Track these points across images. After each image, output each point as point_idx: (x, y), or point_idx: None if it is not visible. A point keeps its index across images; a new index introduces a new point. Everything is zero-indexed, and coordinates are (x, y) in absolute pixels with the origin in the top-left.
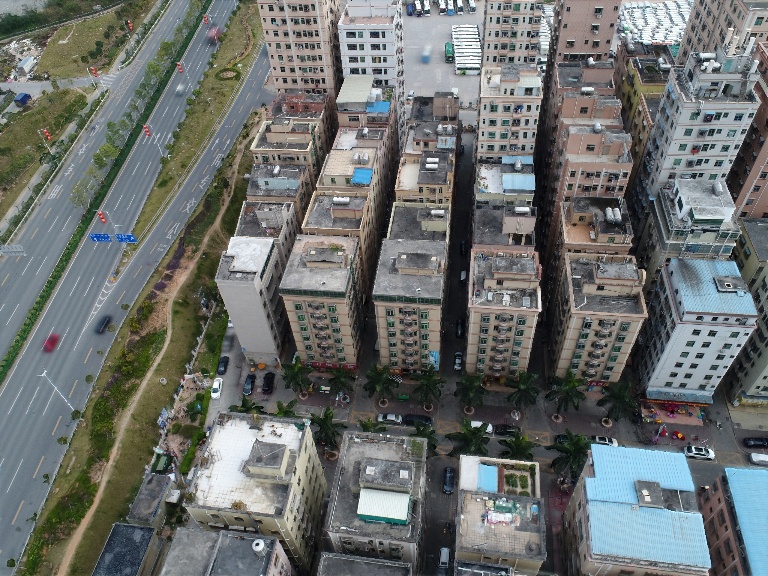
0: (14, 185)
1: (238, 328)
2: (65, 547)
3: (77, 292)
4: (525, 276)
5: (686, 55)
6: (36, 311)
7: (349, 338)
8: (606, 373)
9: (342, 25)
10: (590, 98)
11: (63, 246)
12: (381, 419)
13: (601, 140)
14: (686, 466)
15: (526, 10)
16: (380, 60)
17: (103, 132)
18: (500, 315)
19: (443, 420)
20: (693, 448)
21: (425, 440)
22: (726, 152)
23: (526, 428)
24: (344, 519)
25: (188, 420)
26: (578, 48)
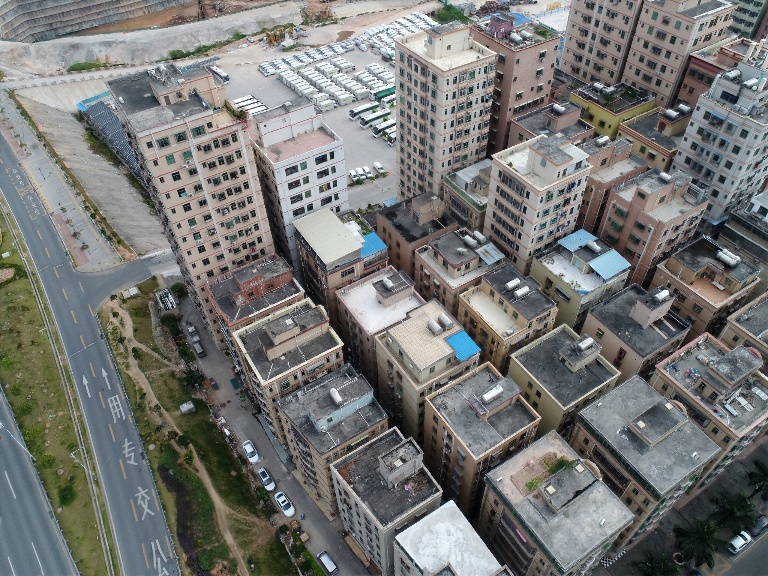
0: None
1: None
2: None
3: None
4: None
5: (579, 72)
6: None
7: None
8: None
9: (279, 163)
10: (610, 148)
11: None
12: None
13: (673, 188)
14: None
15: (480, 75)
16: (329, 186)
17: None
18: (758, 425)
19: None
20: None
21: None
22: None
23: (763, 509)
24: None
25: None
26: (525, 98)
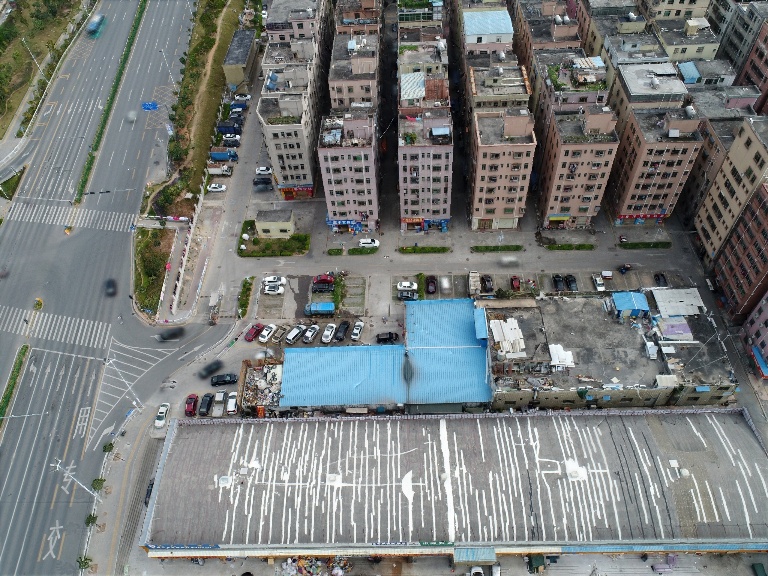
0: None
1: None
2: (207, 55)
3: None
4: None
5: None
6: None
7: None
8: None
9: None
10: None
11: None
12: None
13: None
14: None
15: None
16: None
17: None
18: None
19: (390, 13)
20: None
21: None
22: None
23: None
24: None
25: (252, 25)
26: None
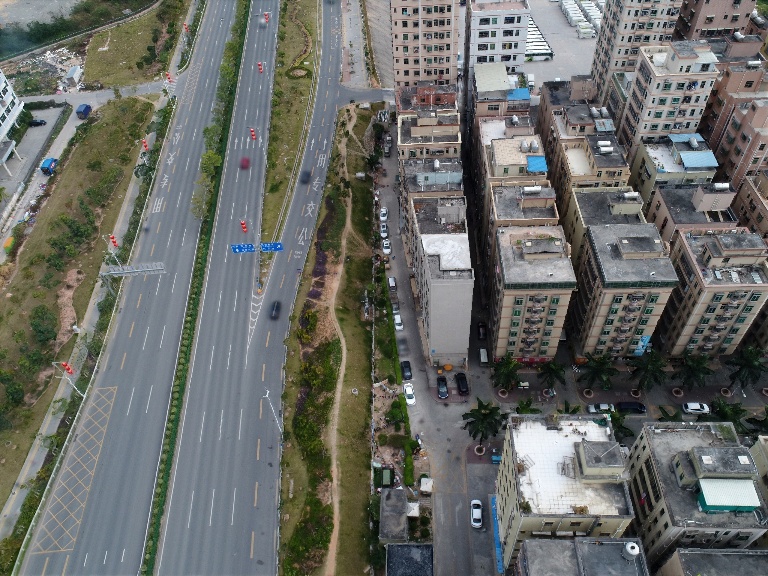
0: (111, 201)
1: (436, 330)
2: (322, 575)
3: (225, 307)
4: (755, 251)
5: None
6: (190, 331)
7: (560, 330)
8: None
9: (477, 12)
10: (758, 71)
11: (190, 261)
12: (594, 410)
13: None
14: None
15: None
16: (511, 46)
17: (186, 140)
18: (735, 293)
19: (654, 405)
20: None
21: (731, 424)
22: None
23: None
24: (683, 512)
25: (392, 430)
26: (716, 23)
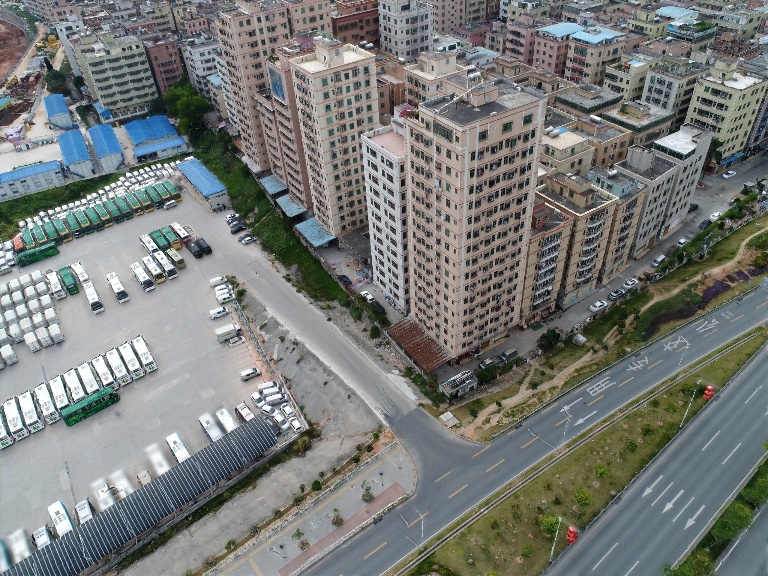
0: None
1: None
2: None
3: None
4: None
5: (265, 85)
6: None
7: None
8: None
9: None
10: None
11: None
12: None
13: None
14: None
15: None
16: None
17: None
18: None
19: None
20: None
21: None
22: None
23: None
24: None
25: None
26: None
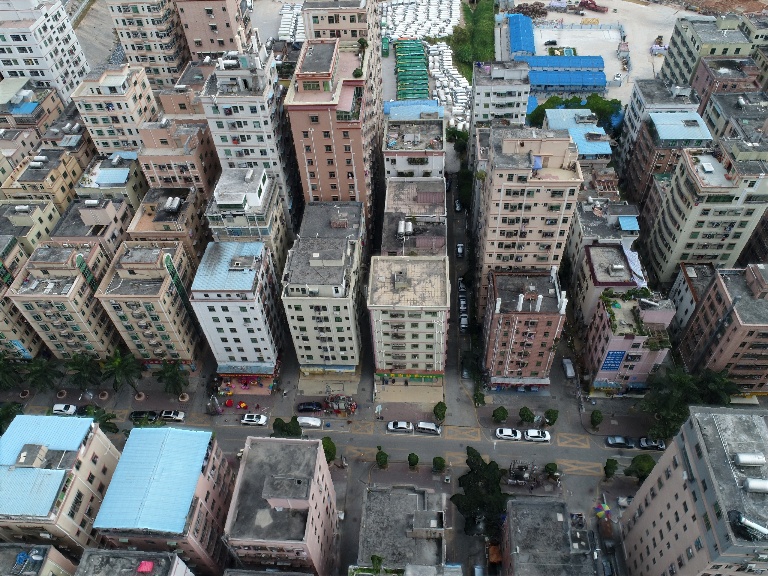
0: None
1: None
2: None
3: None
4: (61, 265)
5: None
6: None
7: None
8: (171, 351)
9: None
10: (182, 95)
11: None
12: None
13: (168, 134)
14: (85, 429)
15: (145, 12)
16: (32, 62)
17: None
18: (38, 302)
19: (35, 405)
20: (246, 415)
21: None
22: (263, 142)
23: (109, 407)
24: None
25: None
26: (207, 47)
